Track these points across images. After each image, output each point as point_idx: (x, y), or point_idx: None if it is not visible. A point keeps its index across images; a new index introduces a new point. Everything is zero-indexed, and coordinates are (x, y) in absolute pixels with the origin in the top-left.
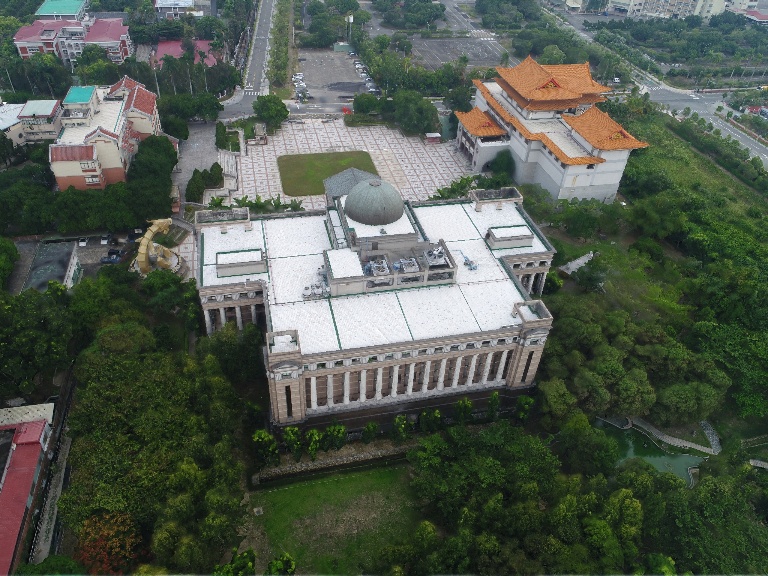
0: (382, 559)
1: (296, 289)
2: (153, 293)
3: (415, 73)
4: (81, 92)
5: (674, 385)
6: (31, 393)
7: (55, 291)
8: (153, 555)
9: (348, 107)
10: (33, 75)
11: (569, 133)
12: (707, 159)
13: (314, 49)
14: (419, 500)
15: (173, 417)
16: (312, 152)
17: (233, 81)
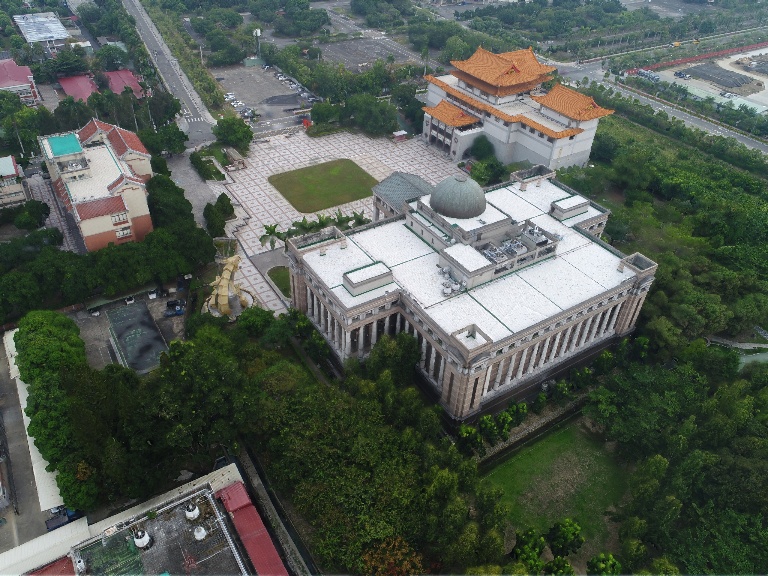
0: (641, 497)
1: (432, 291)
2: (254, 332)
3: (350, 77)
4: (64, 142)
5: (739, 300)
6: (190, 463)
7: (187, 350)
8: (441, 565)
9: (300, 119)
10: None
11: (538, 111)
12: (623, 118)
13: (225, 67)
14: (603, 448)
15: (386, 436)
16: (297, 168)
17: (175, 109)
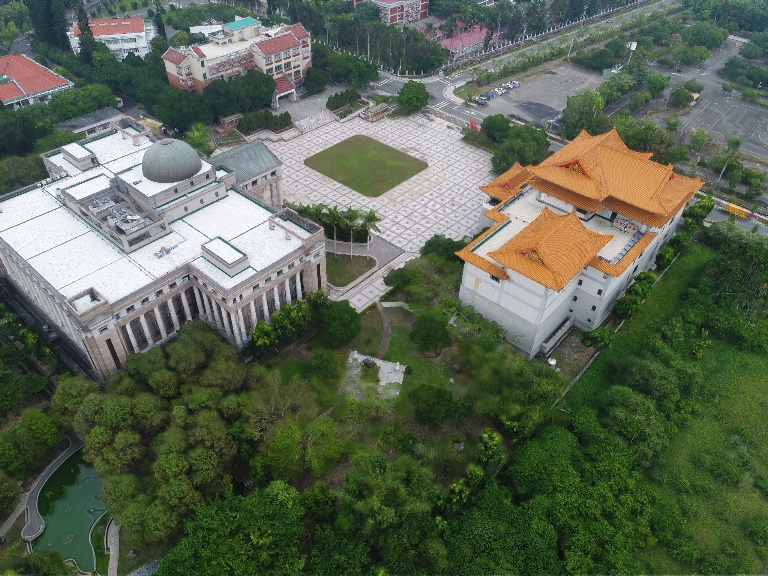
0: None
1: None
2: None
3: (602, 120)
4: (245, 22)
5: (128, 479)
6: None
7: None
8: None
9: None
10: None
11: None
12: None
13: (585, 68)
14: None
15: None
16: (388, 144)
17: (431, 64)
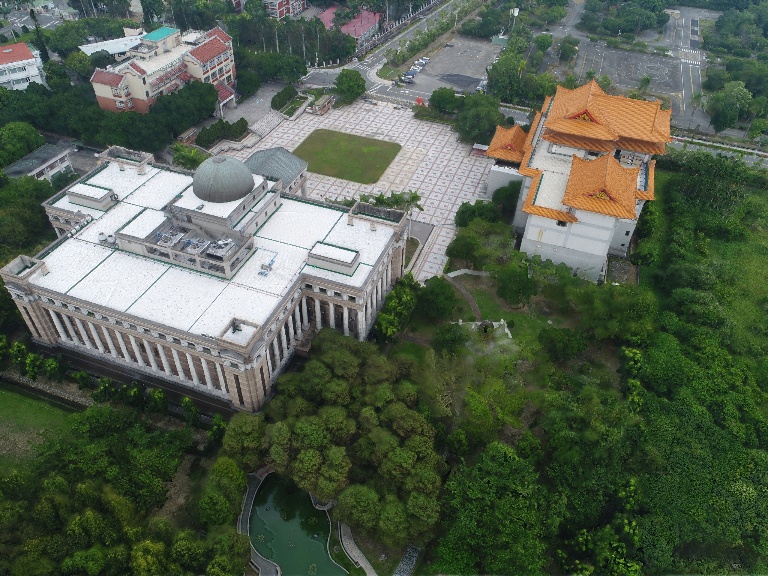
0: None
1: (105, 233)
2: None
3: (528, 79)
4: (163, 32)
5: (365, 487)
6: None
7: None
8: None
9: None
10: (189, 16)
11: None
12: None
13: (473, 38)
14: None
15: None
16: (351, 133)
17: (346, 52)
